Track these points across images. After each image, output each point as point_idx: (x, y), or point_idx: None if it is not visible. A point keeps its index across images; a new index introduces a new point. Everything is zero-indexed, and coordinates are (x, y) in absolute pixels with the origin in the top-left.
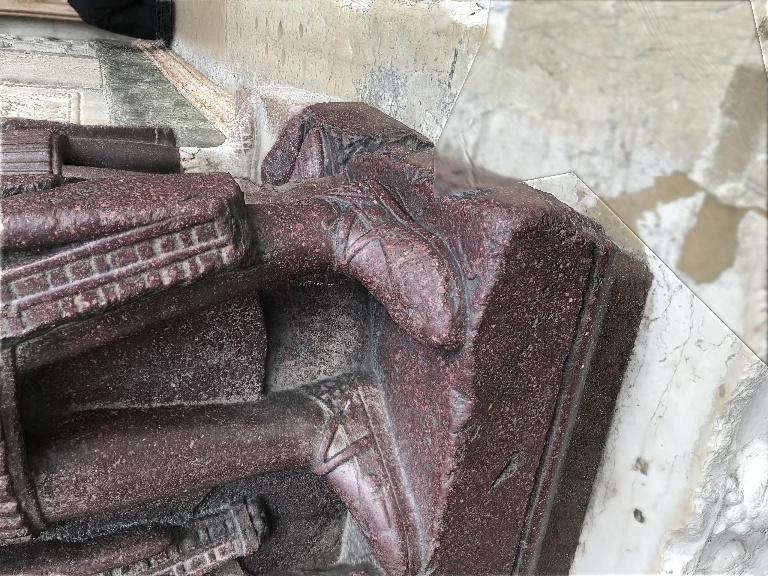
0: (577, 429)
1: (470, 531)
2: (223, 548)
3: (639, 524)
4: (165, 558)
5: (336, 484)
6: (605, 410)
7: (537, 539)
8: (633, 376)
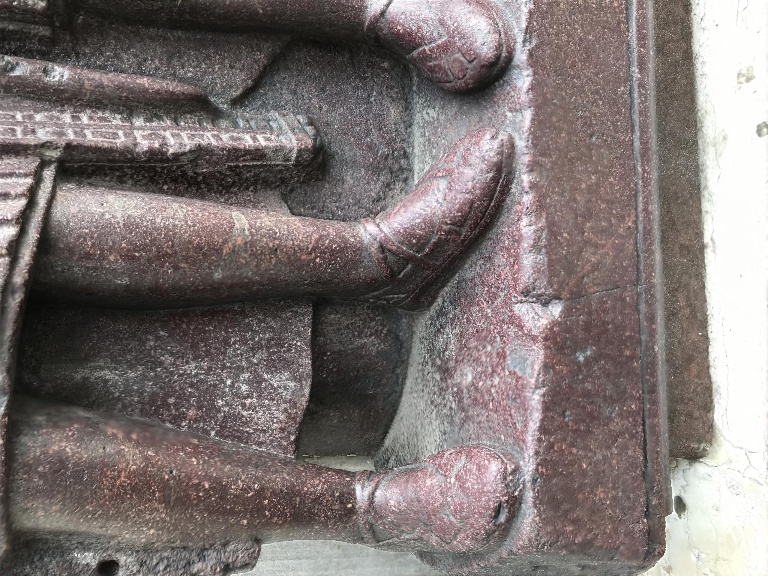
0: (659, 74)
1: (566, 7)
2: (268, 138)
3: (767, 138)
4: (197, 126)
5: (398, 12)
6: (683, 59)
7: (649, 73)
8: (701, 7)
